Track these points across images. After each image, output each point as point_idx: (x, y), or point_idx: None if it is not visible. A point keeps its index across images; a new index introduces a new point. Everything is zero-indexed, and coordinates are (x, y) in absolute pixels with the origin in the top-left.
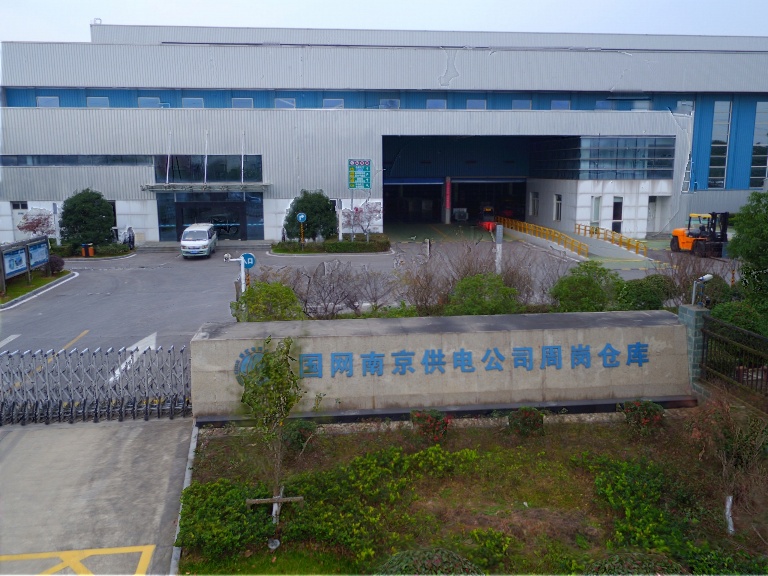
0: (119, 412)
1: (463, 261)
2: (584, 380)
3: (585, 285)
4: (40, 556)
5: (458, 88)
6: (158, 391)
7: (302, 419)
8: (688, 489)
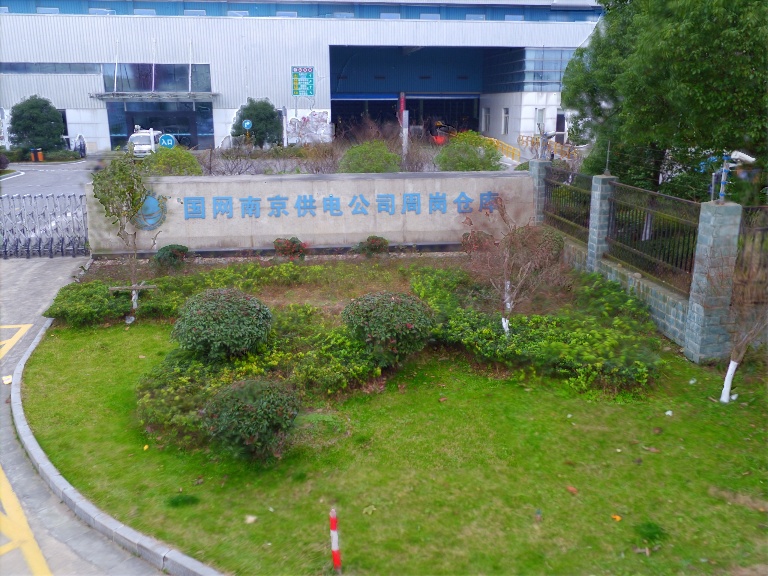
0: (27, 252)
1: None
2: (440, 224)
3: (462, 153)
4: None
5: (411, 1)
6: (62, 234)
7: None
8: (483, 283)
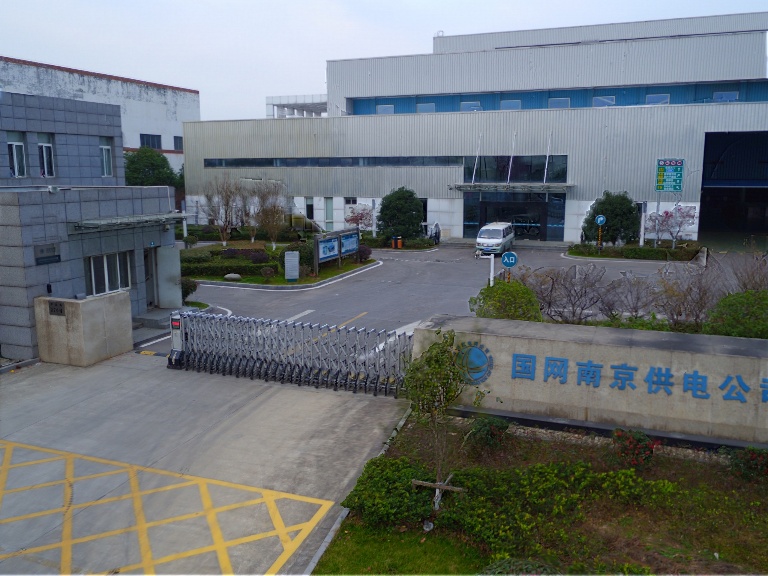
0: (355, 385)
1: (753, 275)
2: None
3: None
4: (249, 489)
5: None
6: (389, 371)
7: (508, 418)
8: None
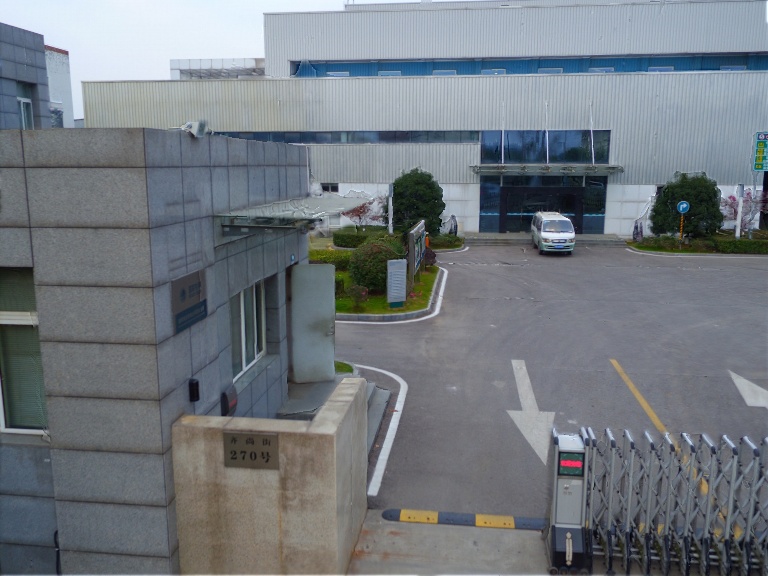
0: None
1: None
2: None
3: None
4: None
5: None
6: None
7: None
8: None
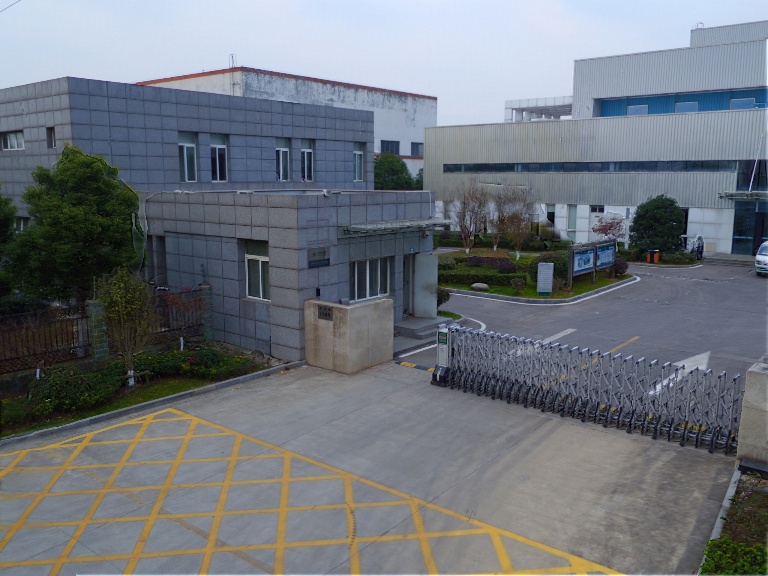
0: (654, 429)
1: None
2: None
3: None
4: (552, 551)
5: None
6: (700, 418)
7: None
8: None
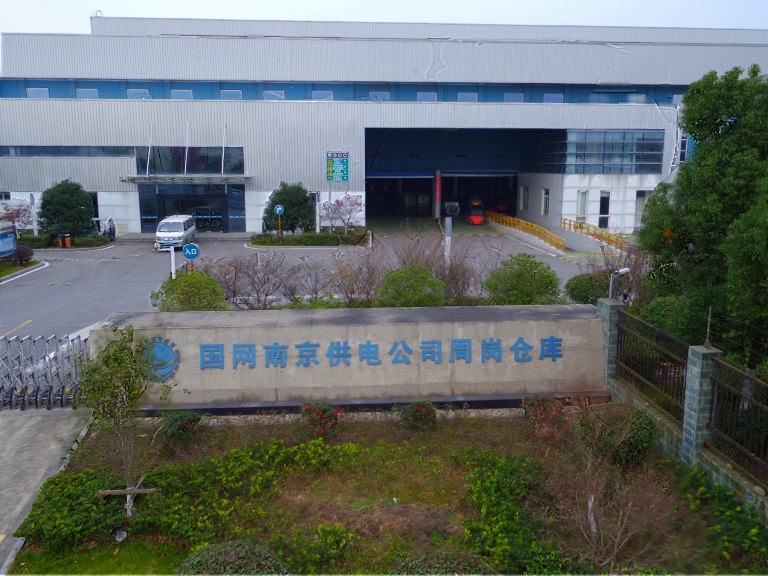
0: (23, 401)
1: (410, 253)
2: (495, 374)
3: (515, 278)
4: None
5: (448, 81)
6: (63, 380)
7: (201, 410)
8: (557, 487)
